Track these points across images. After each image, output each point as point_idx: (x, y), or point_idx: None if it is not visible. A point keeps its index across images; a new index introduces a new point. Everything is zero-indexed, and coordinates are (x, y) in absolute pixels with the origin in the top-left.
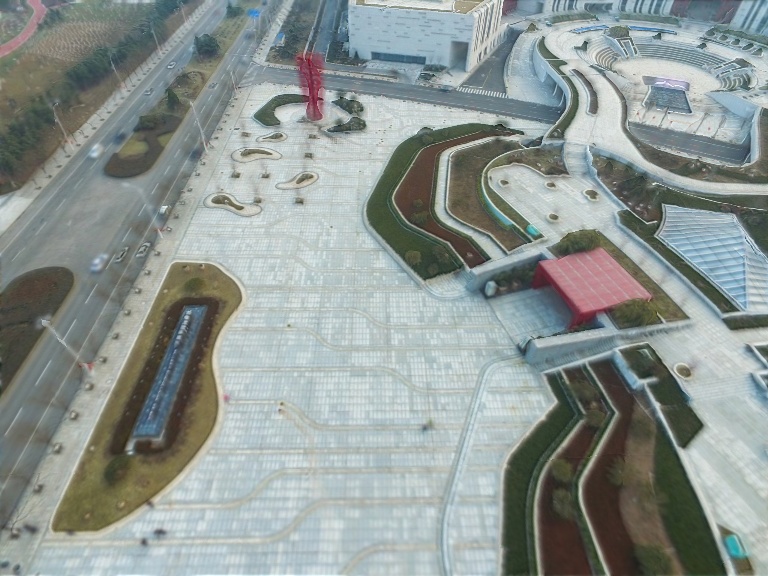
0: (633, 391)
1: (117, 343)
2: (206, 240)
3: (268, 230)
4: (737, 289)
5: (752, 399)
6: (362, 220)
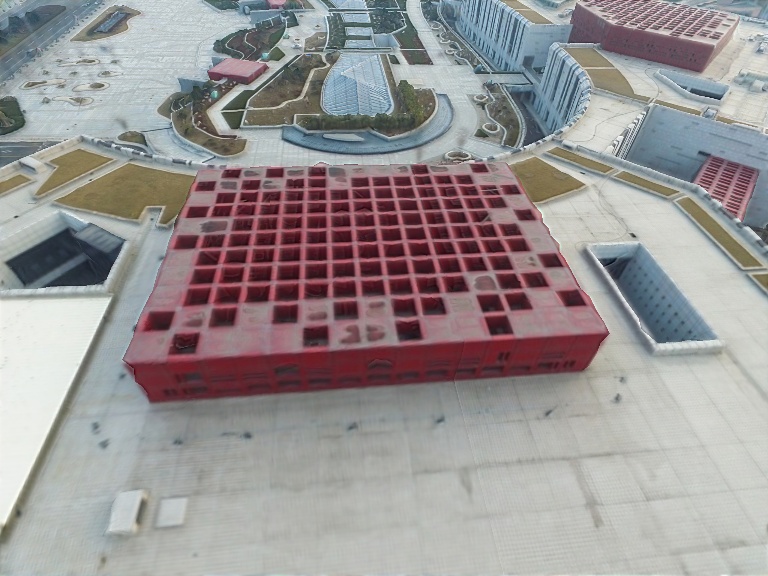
0: (282, 23)
1: (87, 19)
2: (126, 3)
3: (156, 2)
4: (341, 4)
5: (322, 22)
6: (202, 1)
